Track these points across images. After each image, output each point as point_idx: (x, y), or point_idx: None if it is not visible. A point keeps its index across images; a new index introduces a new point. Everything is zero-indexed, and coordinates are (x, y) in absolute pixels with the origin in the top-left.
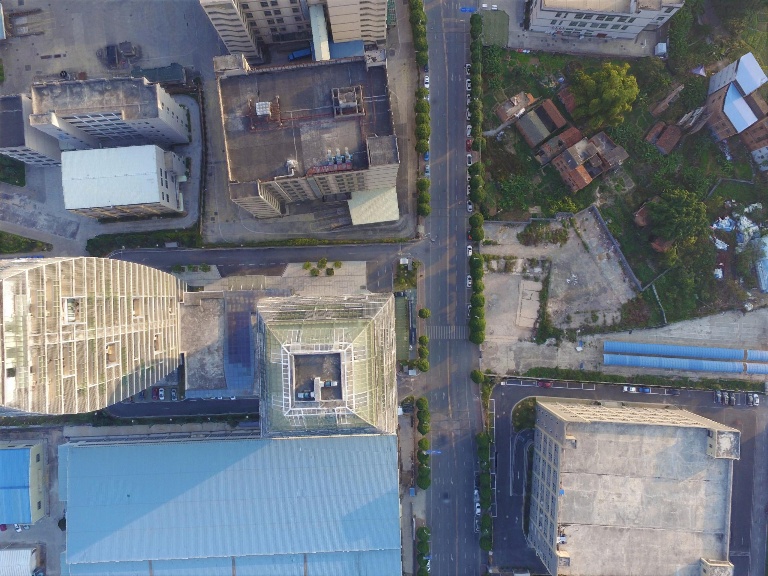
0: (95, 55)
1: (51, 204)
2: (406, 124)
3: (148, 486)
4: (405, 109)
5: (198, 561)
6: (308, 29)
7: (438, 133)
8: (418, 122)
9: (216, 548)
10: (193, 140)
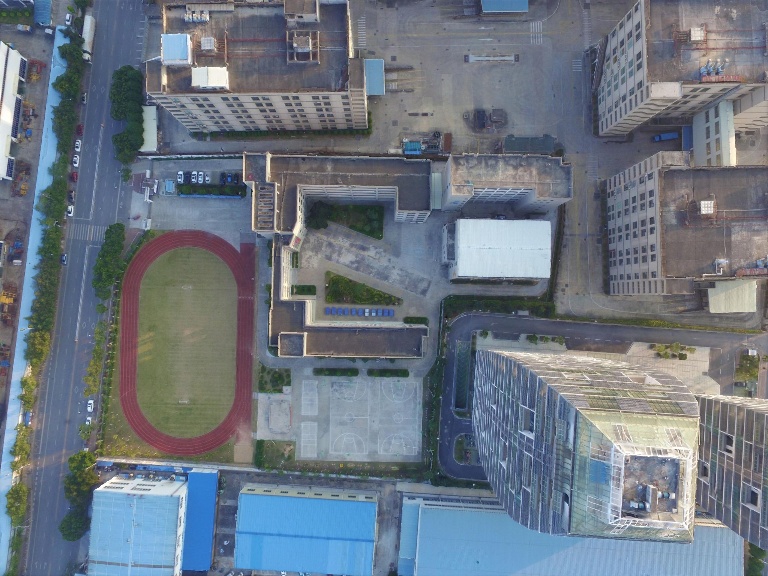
0: (461, 117)
1: (405, 259)
2: None
3: (497, 554)
4: None
5: None
6: (688, 116)
7: None
8: None
9: None
10: (549, 210)
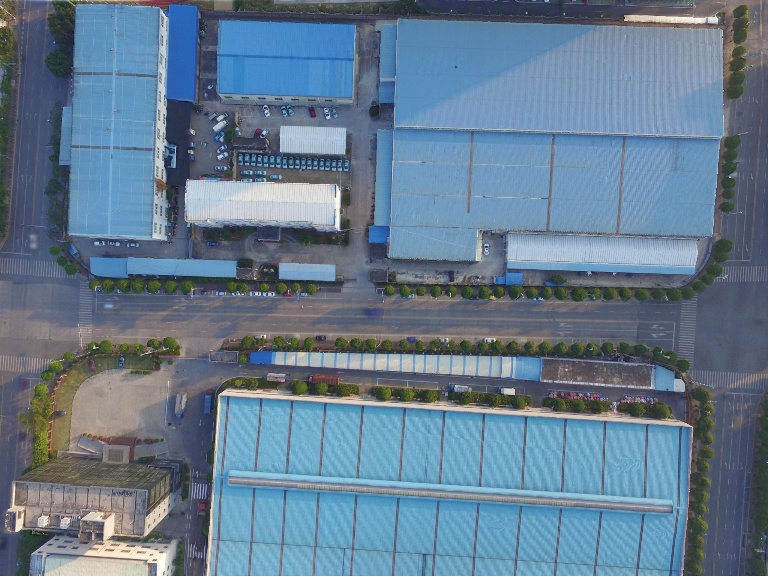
0: None
1: None
2: None
3: (475, 60)
4: None
5: (519, 137)
6: None
7: None
8: None
9: (541, 122)
10: None
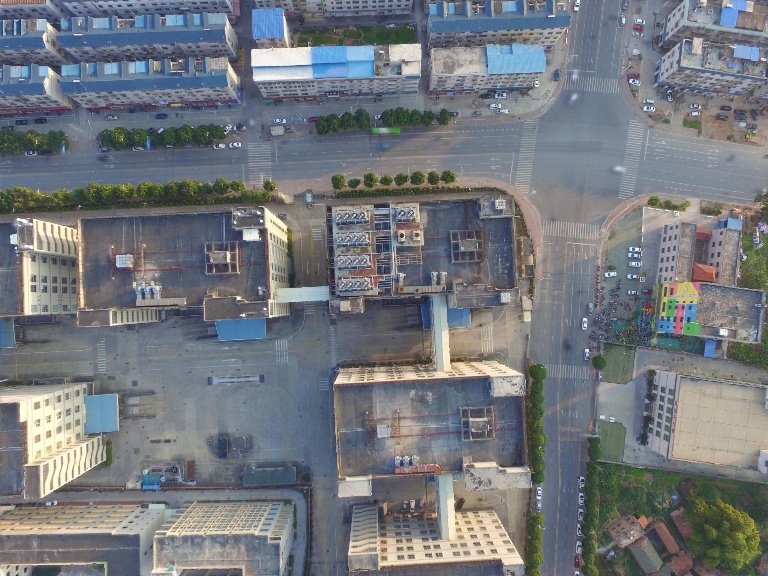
0: (205, 442)
1: None
2: (515, 533)
3: None
4: (515, 518)
5: None
6: None
7: (547, 546)
8: (531, 549)
9: None
10: (298, 536)
